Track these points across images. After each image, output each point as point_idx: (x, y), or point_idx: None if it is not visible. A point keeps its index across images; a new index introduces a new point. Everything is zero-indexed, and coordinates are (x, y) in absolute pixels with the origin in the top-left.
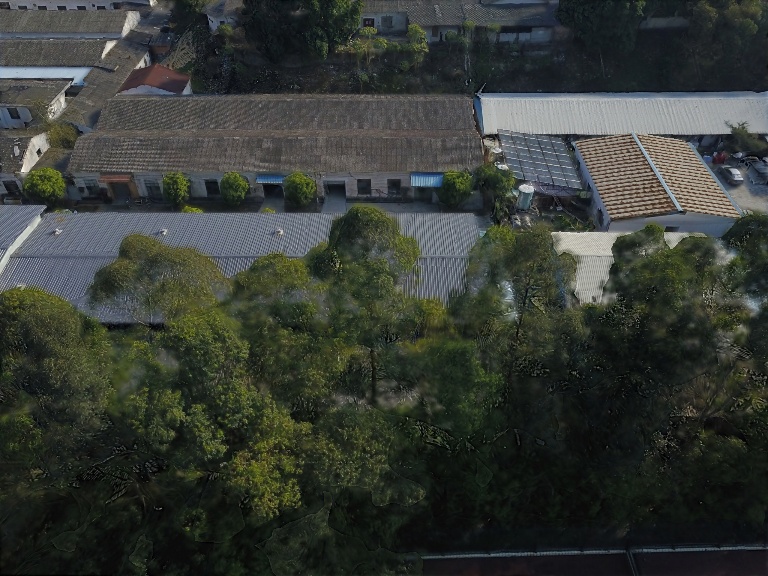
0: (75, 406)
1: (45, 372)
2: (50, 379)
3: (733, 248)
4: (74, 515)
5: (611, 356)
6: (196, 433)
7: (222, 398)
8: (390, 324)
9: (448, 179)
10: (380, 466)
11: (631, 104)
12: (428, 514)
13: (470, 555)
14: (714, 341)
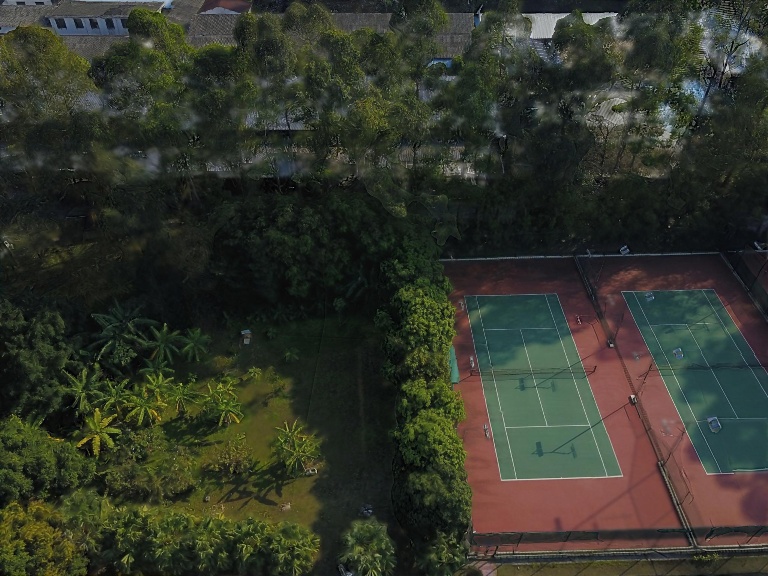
0: (281, 64)
1: (272, 39)
2: (275, 42)
3: (620, 21)
4: (238, 200)
5: (552, 81)
6: (337, 85)
7: (349, 70)
8: (428, 72)
9: (456, 60)
10: (426, 128)
11: (595, 17)
12: None
13: (474, 259)
14: (607, 66)
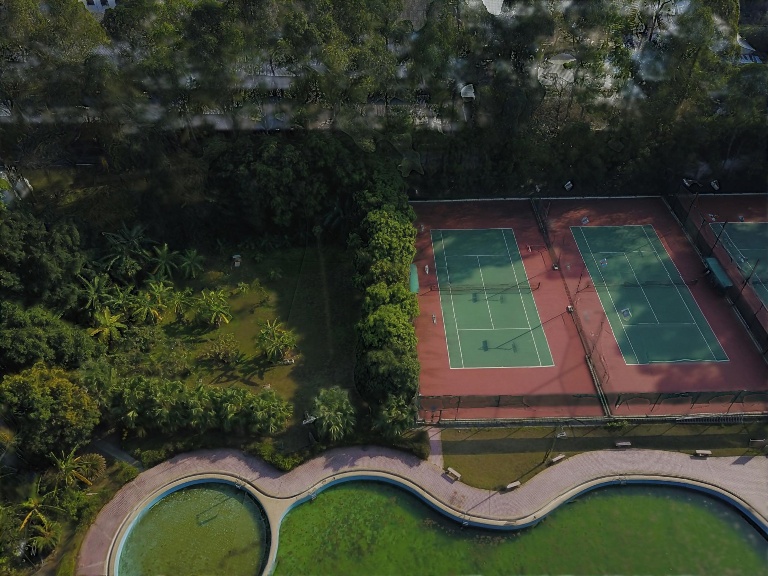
0: (265, 14)
1: None
2: None
3: None
4: None
5: (503, 35)
6: (313, 32)
7: None
8: (396, 28)
9: None
10: (391, 73)
11: None
12: (417, 173)
13: (441, 201)
14: (550, 21)
